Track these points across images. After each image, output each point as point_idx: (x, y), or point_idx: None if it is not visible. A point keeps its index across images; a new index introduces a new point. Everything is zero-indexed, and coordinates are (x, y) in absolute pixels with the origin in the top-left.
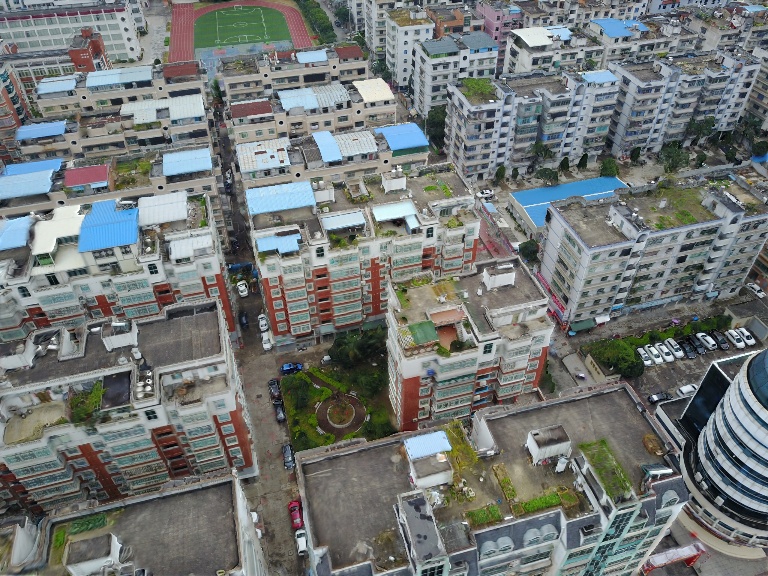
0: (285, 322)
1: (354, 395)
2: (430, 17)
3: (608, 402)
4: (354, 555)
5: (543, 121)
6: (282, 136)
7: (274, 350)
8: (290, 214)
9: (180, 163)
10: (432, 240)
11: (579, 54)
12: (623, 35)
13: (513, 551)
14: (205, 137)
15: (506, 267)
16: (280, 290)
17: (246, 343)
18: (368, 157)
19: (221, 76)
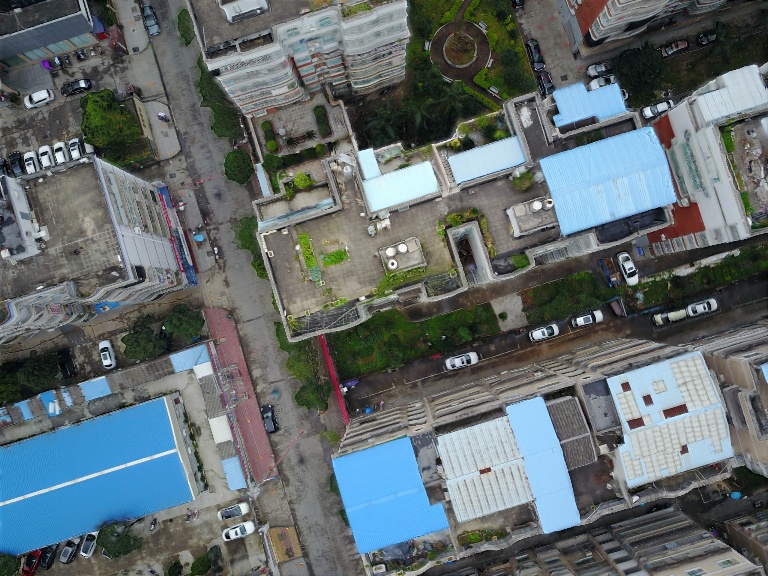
0: None
1: (446, 79)
2: None
3: None
4: None
5: None
6: None
7: None
8: None
9: None
10: None
11: None
12: None
13: None
14: None
15: None
16: None
17: None
18: None
19: None
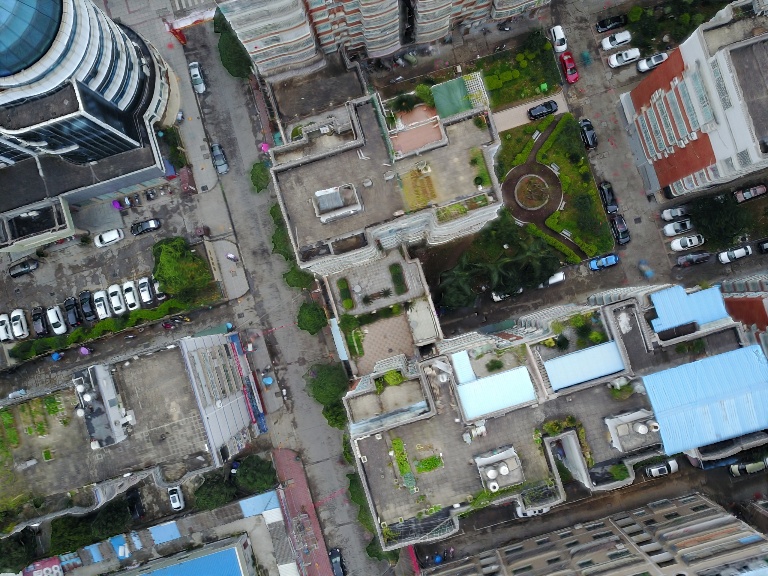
0: None
1: (517, 221)
2: None
3: None
4: None
5: None
6: None
7: None
8: None
9: None
10: None
11: None
12: None
13: None
14: None
15: (327, 191)
16: None
17: None
18: None
19: None
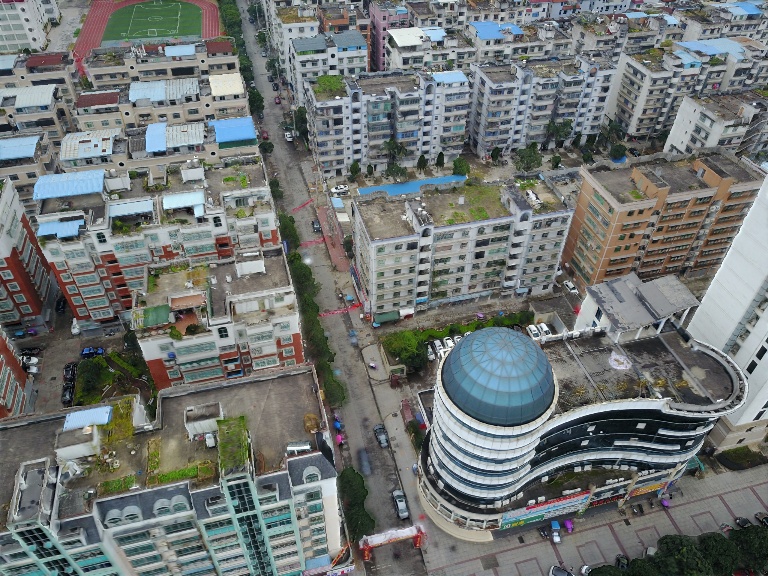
0: (84, 307)
1: (145, 379)
2: (319, 15)
3: (290, 383)
4: None
5: (396, 119)
6: (130, 127)
7: (82, 335)
8: (81, 201)
9: (3, 150)
10: (222, 229)
11: (451, 55)
12: (494, 38)
13: (145, 520)
14: (52, 126)
15: (251, 255)
16: (70, 275)
17: (57, 327)
18: (195, 149)
19: (87, 67)
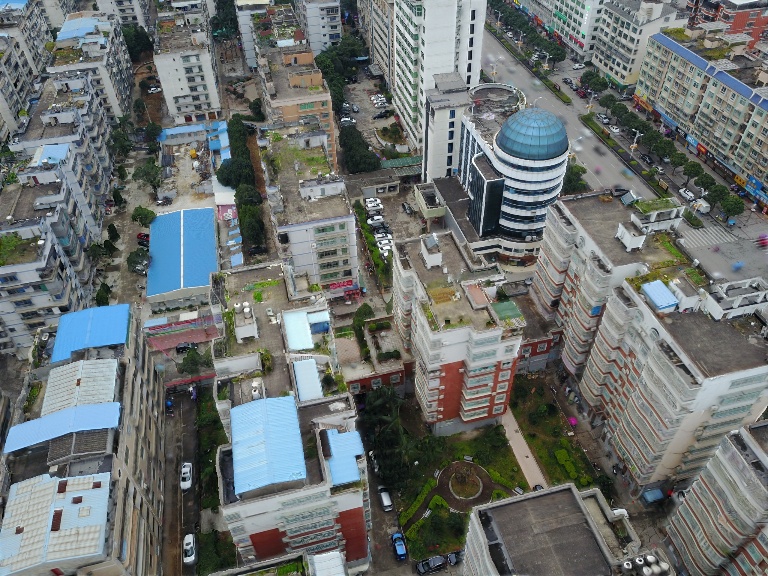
0: None
1: (439, 473)
2: None
3: (574, 211)
4: (761, 345)
5: None
6: None
7: (366, 574)
8: None
9: None
10: None
11: None
12: None
13: None
14: None
15: None
16: None
17: None
18: None
19: None
